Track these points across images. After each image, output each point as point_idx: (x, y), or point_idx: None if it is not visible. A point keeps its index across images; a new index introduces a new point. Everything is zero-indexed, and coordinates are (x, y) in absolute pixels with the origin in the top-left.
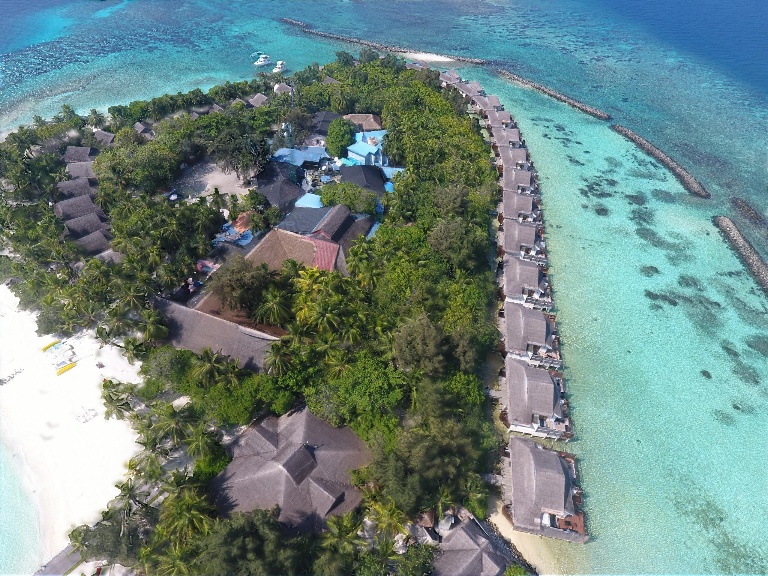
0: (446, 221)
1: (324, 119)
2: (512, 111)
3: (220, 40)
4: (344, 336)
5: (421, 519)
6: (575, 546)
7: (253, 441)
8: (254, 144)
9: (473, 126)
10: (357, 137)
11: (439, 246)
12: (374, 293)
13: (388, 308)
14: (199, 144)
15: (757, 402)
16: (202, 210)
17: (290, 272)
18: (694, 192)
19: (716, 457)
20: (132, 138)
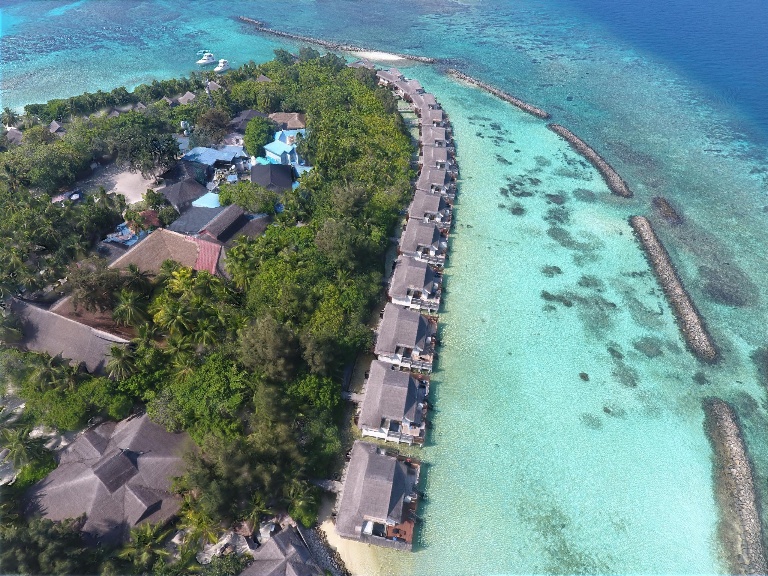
0: (335, 221)
1: (247, 118)
2: (451, 110)
3: (170, 38)
4: (197, 339)
5: (240, 527)
6: (403, 554)
7: (80, 447)
8: (158, 143)
9: (398, 125)
10: (276, 136)
11: (324, 246)
12: (247, 294)
13: (257, 310)
14: None
15: (630, 405)
16: None
17: (164, 273)
18: (616, 191)
19: (573, 462)
20: (40, 137)
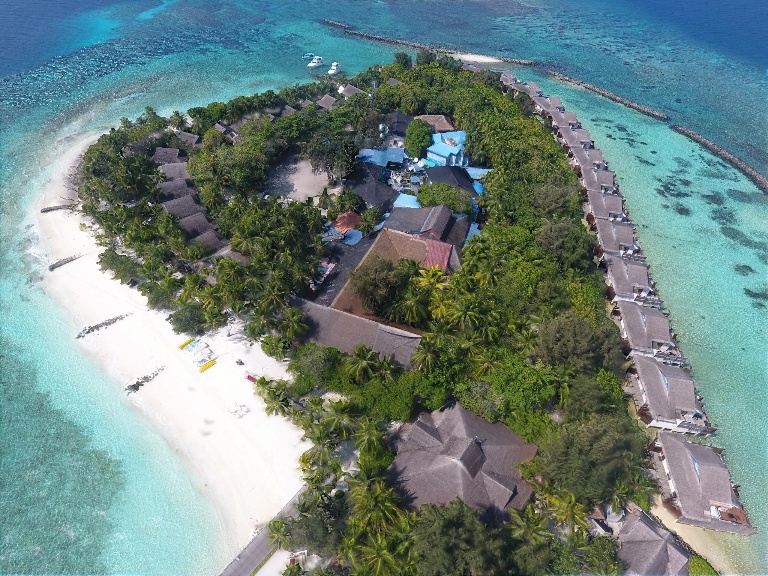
0: (552, 221)
1: (398, 120)
2: None
3: (268, 42)
4: (484, 334)
5: (592, 511)
6: (739, 538)
7: (416, 436)
8: (346, 145)
9: (546, 127)
10: (435, 138)
11: (549, 245)
12: (495, 292)
13: (513, 306)
14: (282, 145)
15: None
16: (308, 210)
17: (410, 271)
18: None
19: None
20: (220, 139)
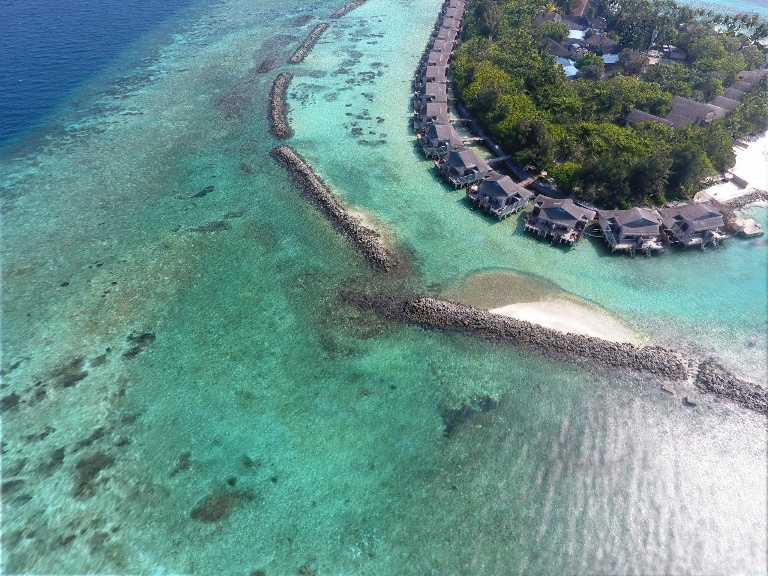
0: None
1: None
2: (405, 155)
3: None
4: None
5: None
6: None
7: None
8: None
9: None
10: None
11: None
12: None
13: None
14: None
15: None
16: None
17: None
18: None
19: None
20: None
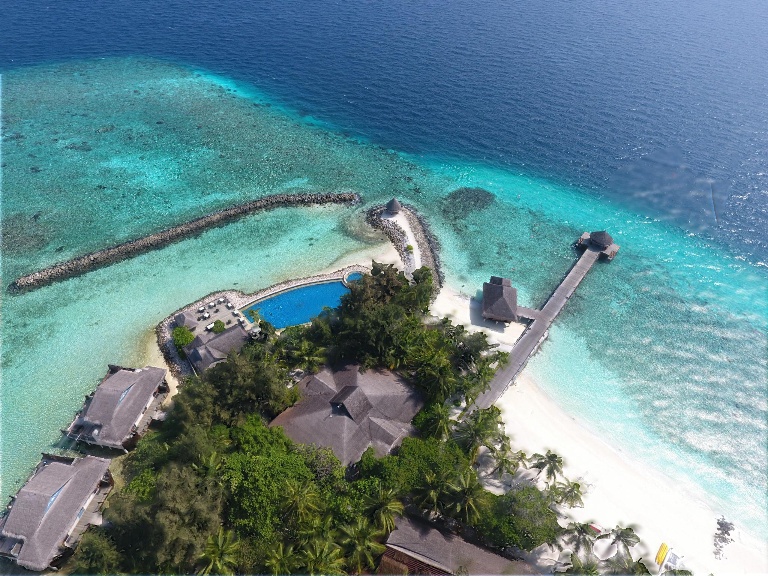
0: None
1: None
2: None
3: None
4: None
5: None
6: None
7: (394, 429)
8: None
9: None
10: None
11: None
12: None
13: None
14: None
15: None
16: None
17: None
18: None
19: None
20: None
